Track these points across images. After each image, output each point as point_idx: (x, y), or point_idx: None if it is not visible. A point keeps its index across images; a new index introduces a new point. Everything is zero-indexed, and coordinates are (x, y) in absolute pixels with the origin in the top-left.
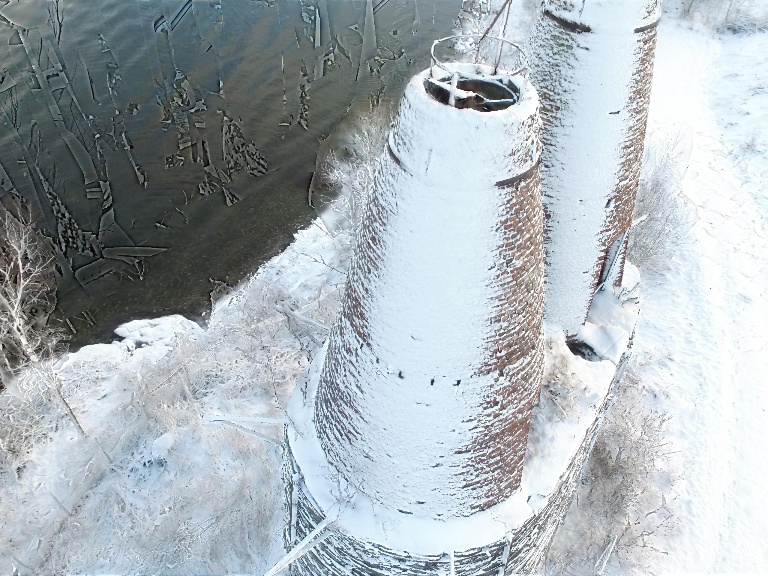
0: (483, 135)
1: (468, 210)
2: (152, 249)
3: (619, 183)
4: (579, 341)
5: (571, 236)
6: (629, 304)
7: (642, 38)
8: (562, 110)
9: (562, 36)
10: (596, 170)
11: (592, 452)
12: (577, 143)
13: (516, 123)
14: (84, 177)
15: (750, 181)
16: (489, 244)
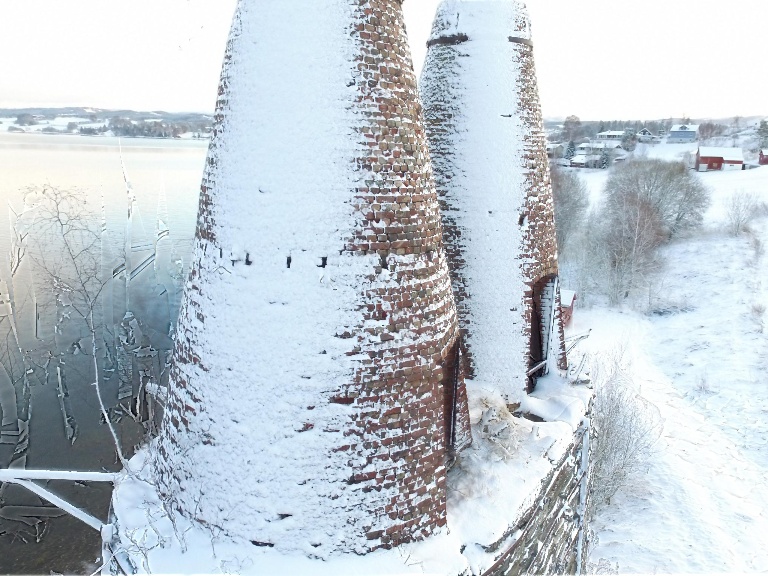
0: None
1: None
2: None
3: (528, 197)
4: (524, 413)
5: (487, 257)
6: (580, 386)
7: (518, 49)
8: (454, 116)
9: (444, 51)
10: (499, 175)
11: None
12: (474, 146)
13: None
14: (3, 418)
15: (712, 415)
16: (344, 50)
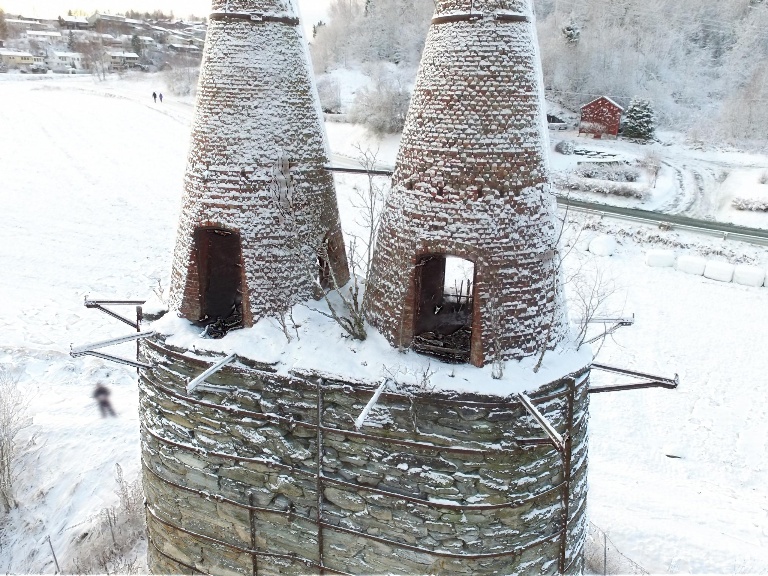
0: None
1: None
2: None
3: None
4: None
5: None
6: None
7: None
8: None
9: None
10: None
11: None
12: None
13: None
14: None
15: None
16: None
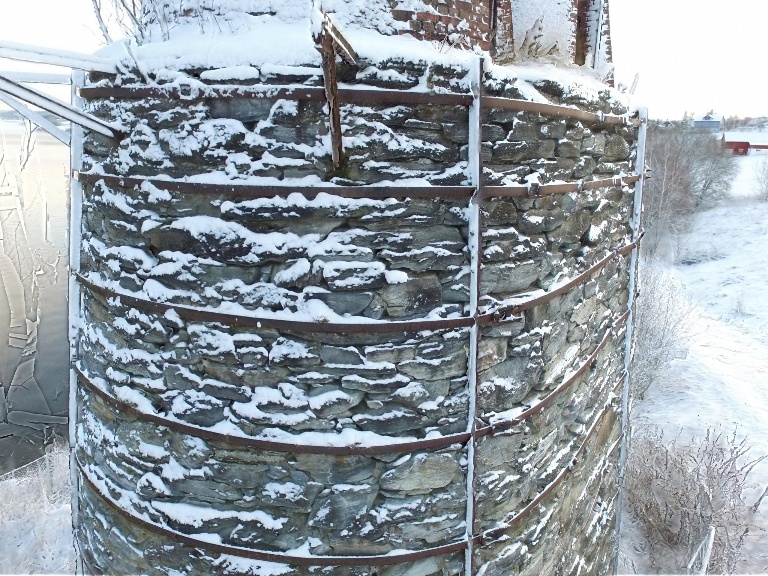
0: None
1: None
2: None
3: None
4: None
5: None
6: None
7: None
8: None
9: None
10: None
11: (641, 521)
12: None
13: None
14: (11, 320)
15: (750, 331)
16: None
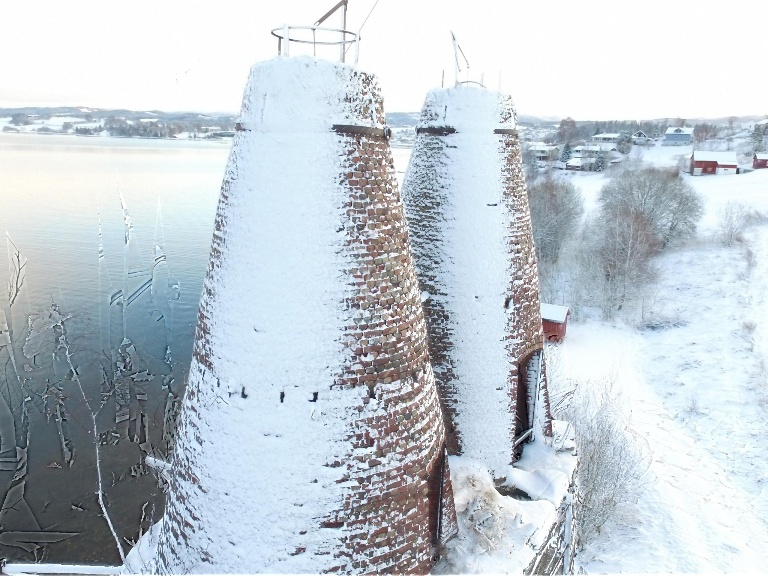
0: (314, 73)
1: (306, 153)
2: (60, 534)
3: (513, 281)
4: (510, 487)
5: (474, 340)
6: (565, 454)
7: (503, 140)
8: (442, 205)
9: (433, 141)
10: (485, 262)
11: None
12: (461, 235)
13: (347, 69)
14: (1, 445)
15: (702, 439)
16: (334, 199)
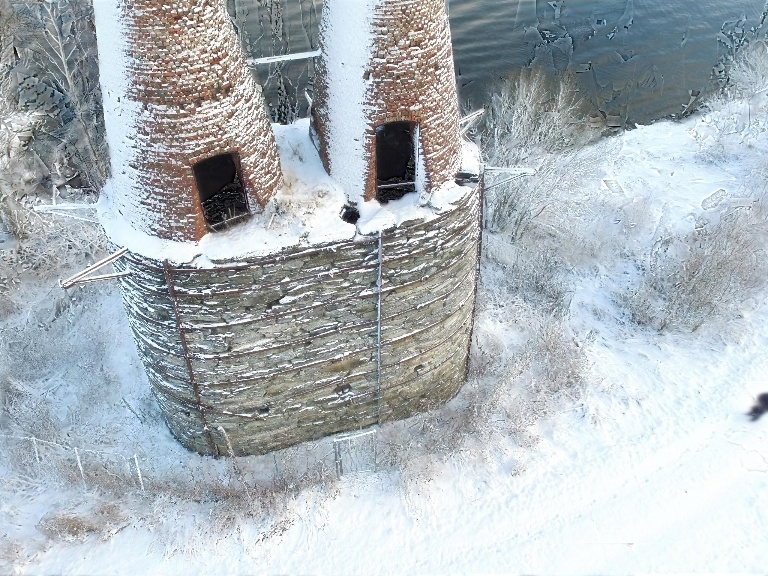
0: None
1: None
2: None
3: (374, 58)
4: (357, 210)
5: (340, 97)
6: (428, 210)
7: None
8: None
9: None
10: (349, 36)
11: None
12: (337, 8)
13: None
14: (309, 71)
15: None
16: None
